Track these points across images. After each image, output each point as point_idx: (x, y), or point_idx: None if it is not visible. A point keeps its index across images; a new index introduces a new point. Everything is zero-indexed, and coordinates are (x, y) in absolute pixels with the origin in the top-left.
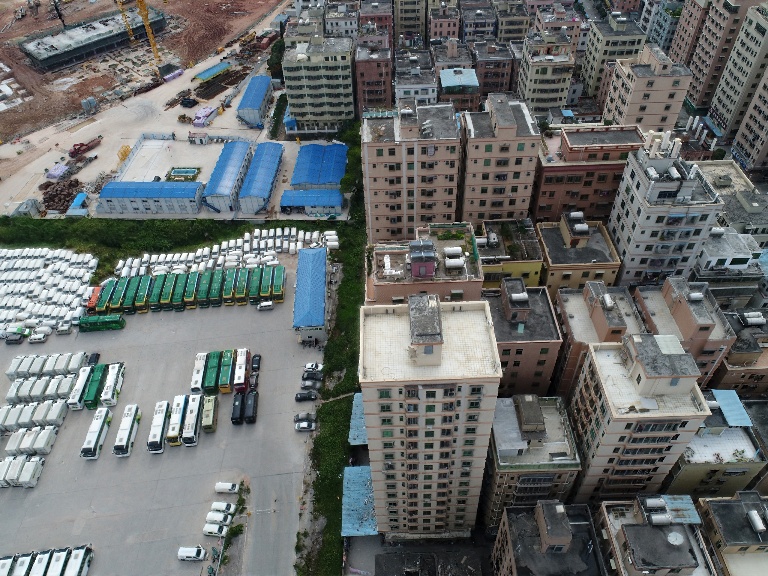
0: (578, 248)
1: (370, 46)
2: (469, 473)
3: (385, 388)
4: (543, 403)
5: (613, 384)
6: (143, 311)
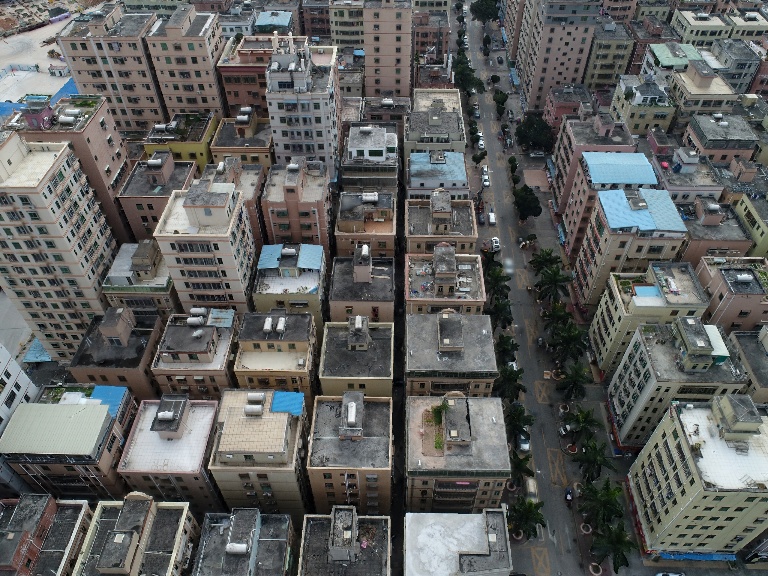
0: (246, 138)
1: None
2: (82, 293)
3: None
4: None
5: (176, 218)
6: None
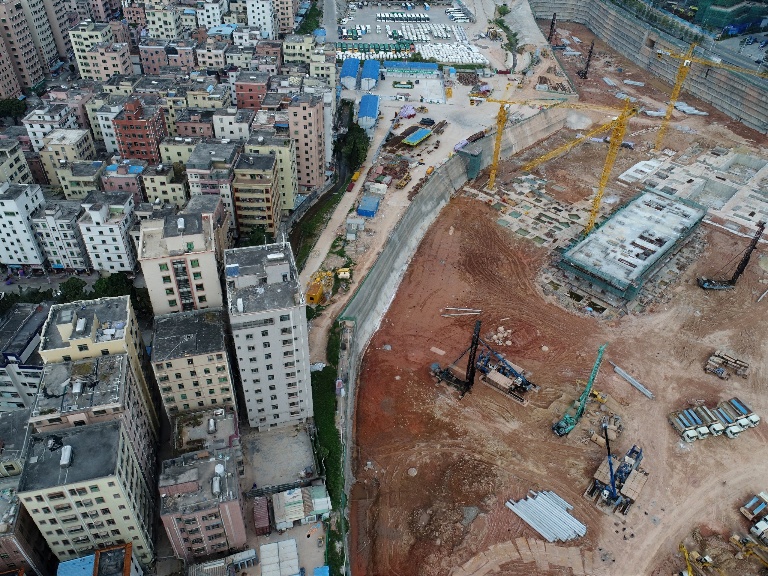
0: None
1: (271, 43)
2: None
3: None
4: None
5: None
6: None
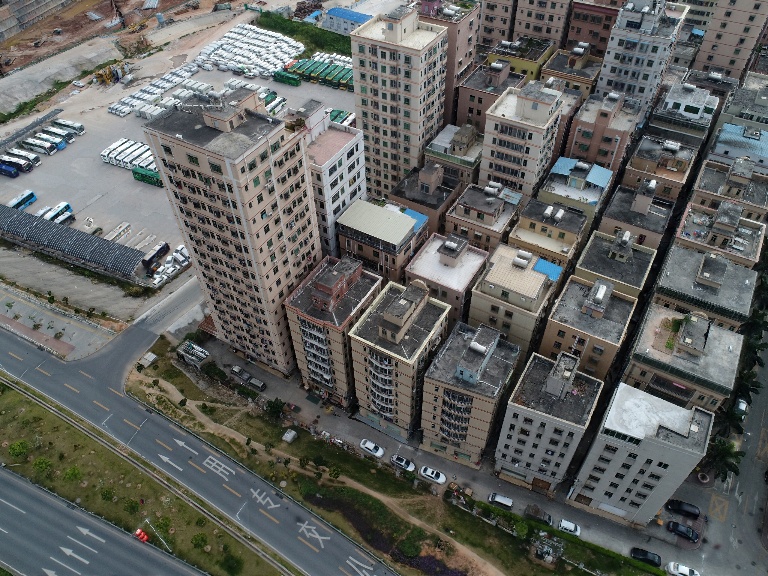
0: (574, 69)
1: None
2: (409, 150)
3: (362, 44)
4: (482, 140)
5: (505, 107)
6: (314, 81)
